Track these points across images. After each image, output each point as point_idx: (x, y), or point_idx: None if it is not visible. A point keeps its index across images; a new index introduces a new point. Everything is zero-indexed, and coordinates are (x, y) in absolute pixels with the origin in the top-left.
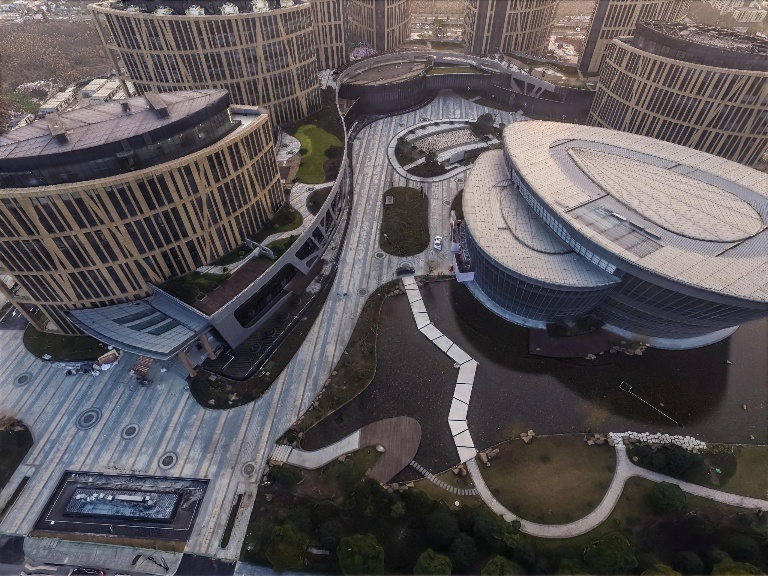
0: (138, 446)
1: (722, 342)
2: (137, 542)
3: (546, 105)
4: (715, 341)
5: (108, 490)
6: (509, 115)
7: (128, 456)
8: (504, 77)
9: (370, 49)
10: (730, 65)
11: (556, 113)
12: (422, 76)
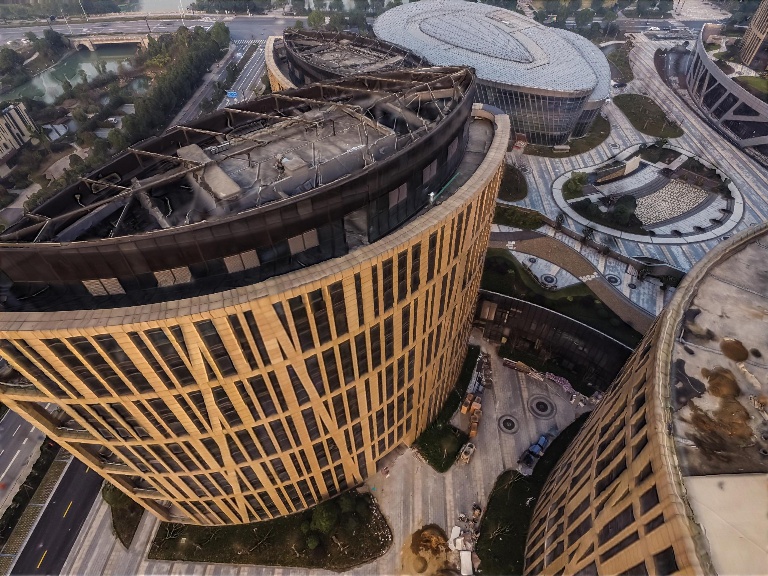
0: (692, 43)
1: None
2: (661, 33)
3: None
4: None
5: (687, 37)
6: None
7: (692, 42)
8: None
9: None
10: None
11: None
12: None
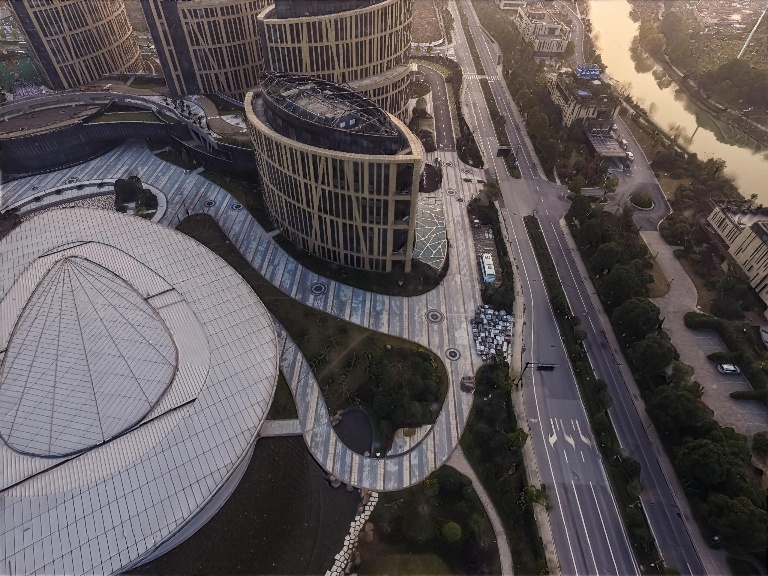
0: None
1: (150, 564)
2: None
3: (219, 163)
4: (138, 564)
5: None
6: (182, 174)
7: None
8: (179, 127)
9: (29, 89)
10: (317, 139)
11: (232, 173)
12: (74, 126)
